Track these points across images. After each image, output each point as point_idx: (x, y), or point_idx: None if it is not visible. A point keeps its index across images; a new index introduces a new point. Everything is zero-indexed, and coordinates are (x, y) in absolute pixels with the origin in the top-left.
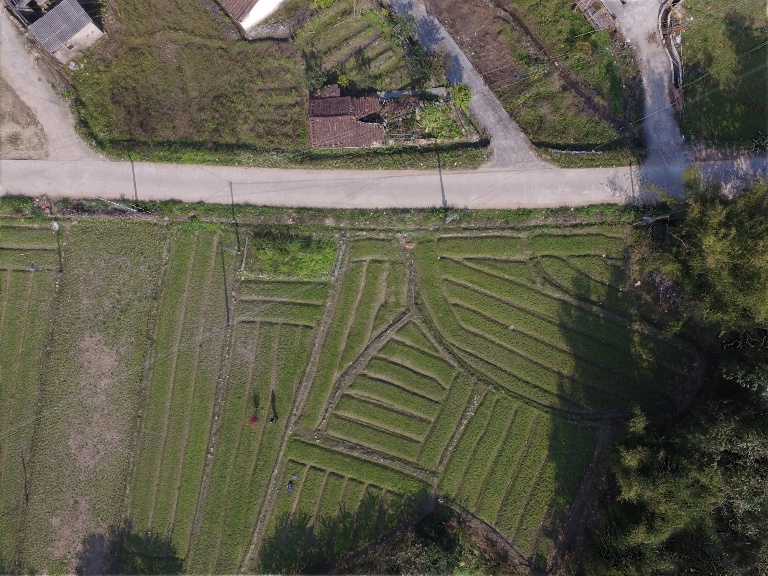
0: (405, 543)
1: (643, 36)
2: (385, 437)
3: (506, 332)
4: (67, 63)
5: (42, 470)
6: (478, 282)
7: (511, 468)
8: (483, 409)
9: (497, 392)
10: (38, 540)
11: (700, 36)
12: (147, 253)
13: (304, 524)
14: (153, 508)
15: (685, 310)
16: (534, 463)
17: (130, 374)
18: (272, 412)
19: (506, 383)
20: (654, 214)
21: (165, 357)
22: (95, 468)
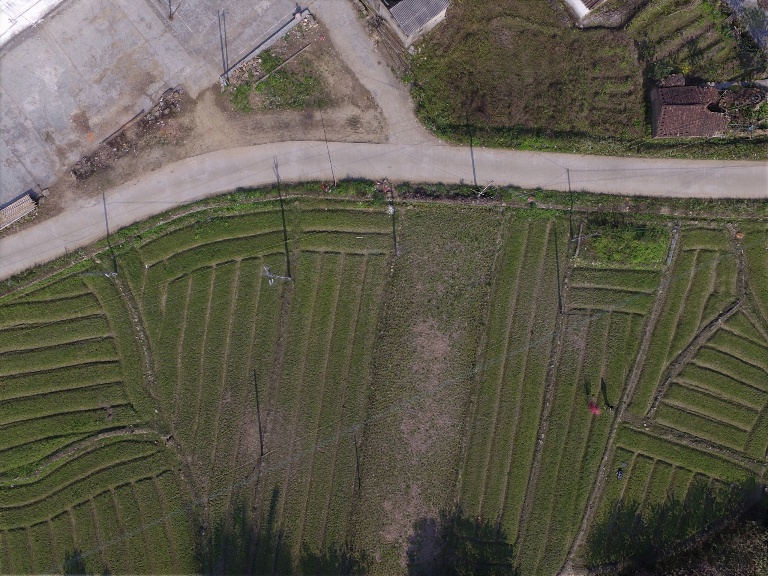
0: (751, 531)
1: None
2: (713, 426)
3: None
4: (408, 47)
5: (374, 454)
6: None
7: None
8: None
9: None
10: (370, 524)
11: None
12: (481, 239)
13: (633, 511)
14: (483, 493)
15: None
16: None
17: (463, 359)
18: (603, 399)
19: None
20: None
21: (498, 343)
22: (427, 453)
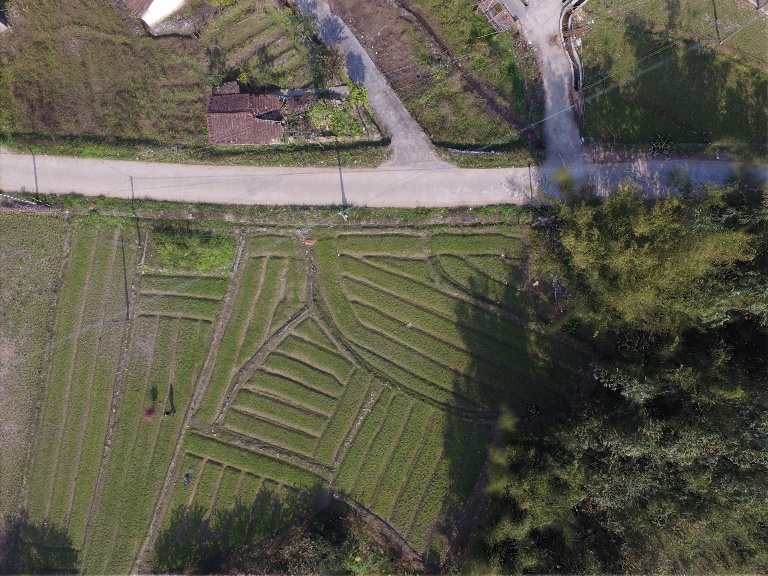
0: (294, 537)
1: (544, 38)
2: (282, 432)
3: (404, 330)
4: None
5: None
6: (377, 280)
7: (406, 464)
8: (379, 406)
9: (394, 389)
10: None
11: (601, 39)
12: (48, 246)
13: (200, 517)
14: (50, 499)
15: (581, 310)
16: (429, 460)
17: (29, 366)
18: (170, 405)
19: (403, 380)
20: (552, 215)
21: (64, 349)
22: None
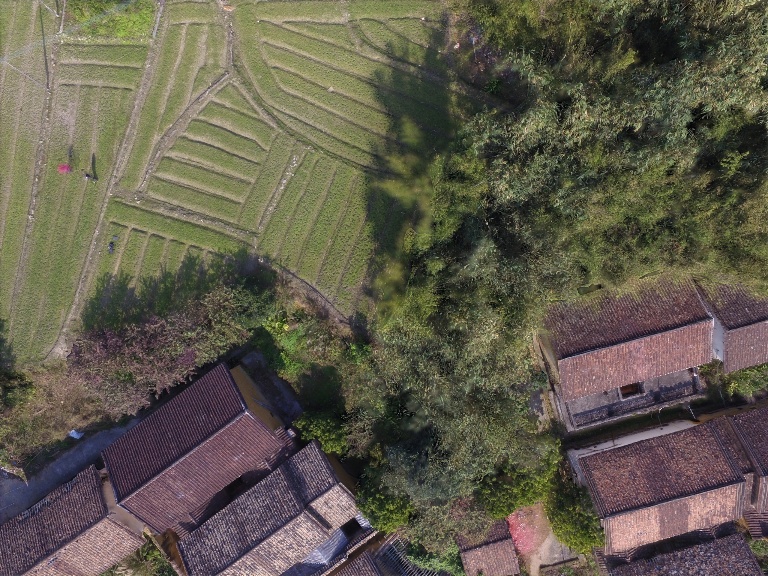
0: (216, 289)
1: None
2: (205, 198)
3: (325, 93)
4: None
5: None
6: (297, 44)
7: (331, 227)
8: (302, 169)
9: (316, 152)
10: None
11: None
12: None
13: (125, 284)
14: None
15: (502, 69)
16: (353, 222)
17: None
18: (92, 174)
19: (325, 144)
20: None
21: None
22: None
